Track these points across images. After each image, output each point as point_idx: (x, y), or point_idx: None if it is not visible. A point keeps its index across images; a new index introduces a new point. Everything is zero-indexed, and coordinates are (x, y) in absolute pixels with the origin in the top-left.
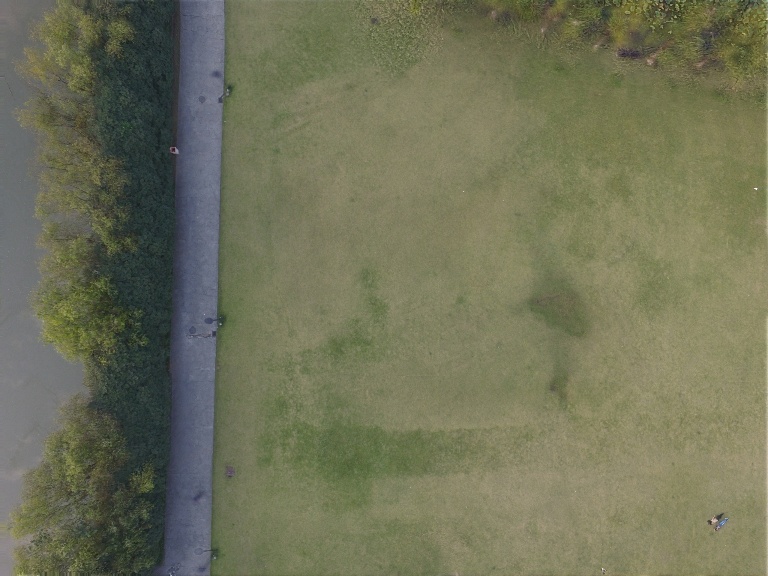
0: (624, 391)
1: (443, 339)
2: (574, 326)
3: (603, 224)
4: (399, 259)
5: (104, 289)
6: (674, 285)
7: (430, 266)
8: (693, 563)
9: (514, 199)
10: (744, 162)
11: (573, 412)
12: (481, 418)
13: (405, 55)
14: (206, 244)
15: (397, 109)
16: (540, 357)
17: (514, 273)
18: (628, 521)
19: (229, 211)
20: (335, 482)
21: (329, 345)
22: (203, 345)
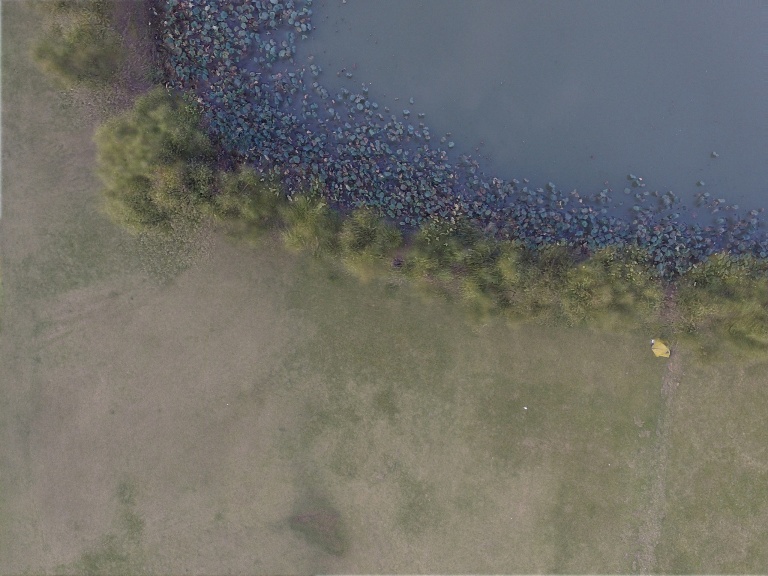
0: None
1: (200, 555)
2: (334, 545)
3: (367, 442)
4: (158, 474)
5: None
6: (435, 507)
7: (189, 481)
8: None
9: (279, 413)
10: (516, 379)
11: None
12: None
13: (175, 261)
14: None
15: (163, 318)
16: (298, 575)
17: (274, 490)
18: None
19: None
20: None
21: (83, 561)
22: None
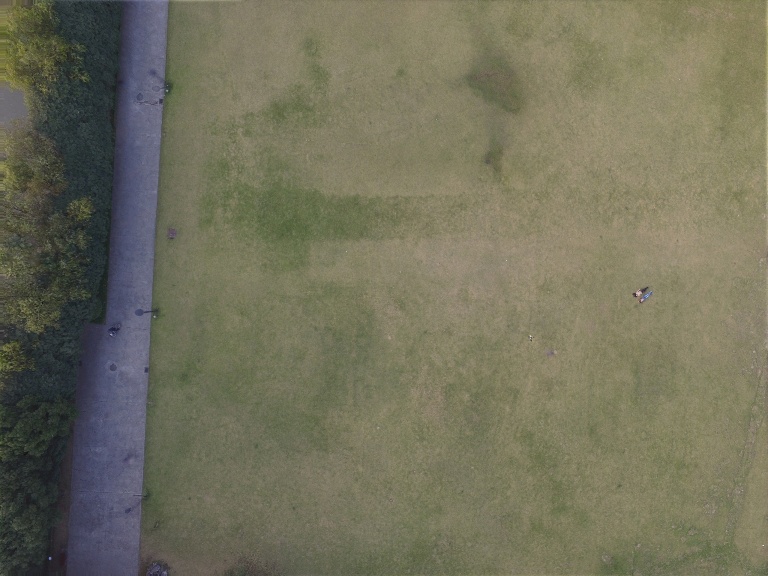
0: (556, 164)
1: (383, 110)
2: (511, 103)
3: (542, 6)
4: (343, 31)
5: (46, 11)
6: (608, 66)
7: (373, 39)
8: (617, 333)
9: None
10: None
11: (507, 184)
12: (417, 186)
13: None
14: (156, 14)
15: None
16: (477, 131)
17: (454, 49)
18: (556, 290)
19: None
20: (273, 243)
21: (272, 109)
22: (150, 112)
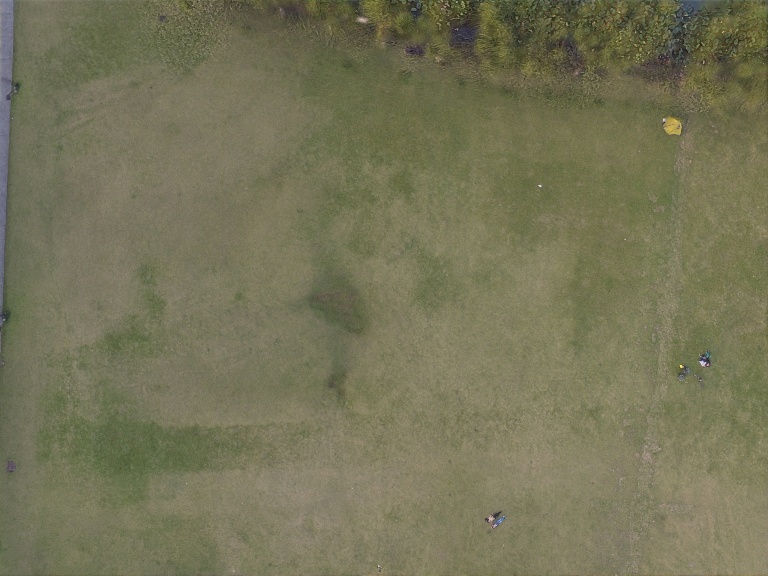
0: (400, 388)
1: (222, 335)
2: (354, 323)
3: (384, 221)
4: (179, 255)
5: None
6: (453, 282)
7: (210, 262)
8: (470, 561)
9: (297, 196)
10: (529, 159)
11: (351, 409)
12: (258, 414)
13: (193, 52)
14: None
15: (182, 106)
16: (319, 354)
17: (294, 270)
18: (404, 518)
19: (14, 207)
20: (112, 477)
21: (106, 341)
22: None
